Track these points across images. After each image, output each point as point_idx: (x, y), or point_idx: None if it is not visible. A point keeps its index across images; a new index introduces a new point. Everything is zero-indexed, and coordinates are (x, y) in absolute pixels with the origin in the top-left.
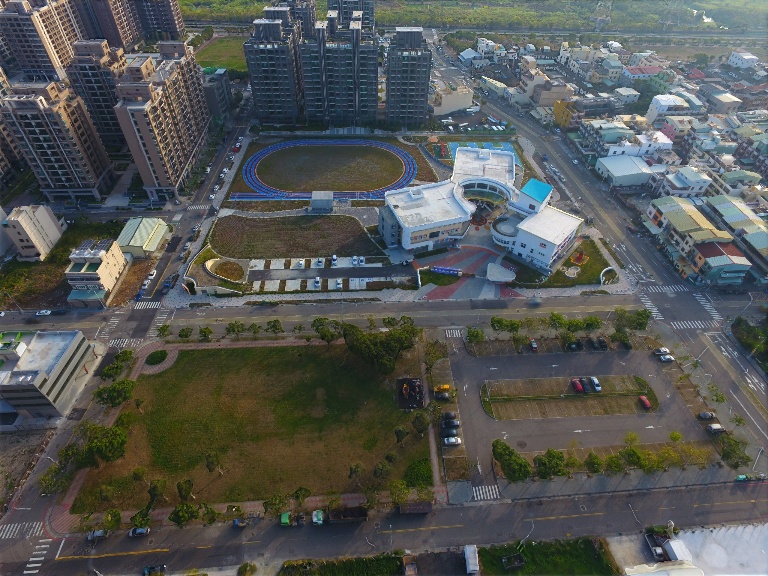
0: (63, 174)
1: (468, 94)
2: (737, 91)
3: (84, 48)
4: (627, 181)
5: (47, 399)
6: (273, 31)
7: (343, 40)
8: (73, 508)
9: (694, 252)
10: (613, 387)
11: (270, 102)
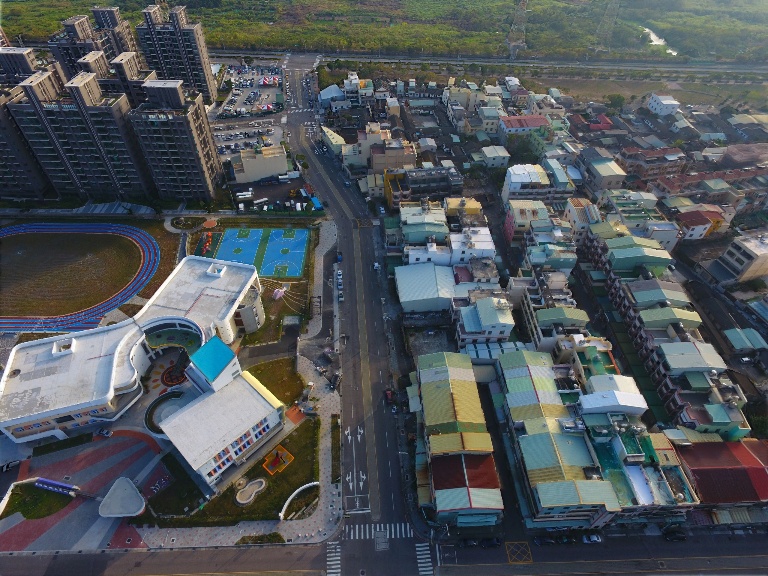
0: None
1: (279, 157)
2: (630, 156)
3: None
4: (421, 306)
5: None
6: None
7: None
8: None
9: (431, 470)
10: None
11: None
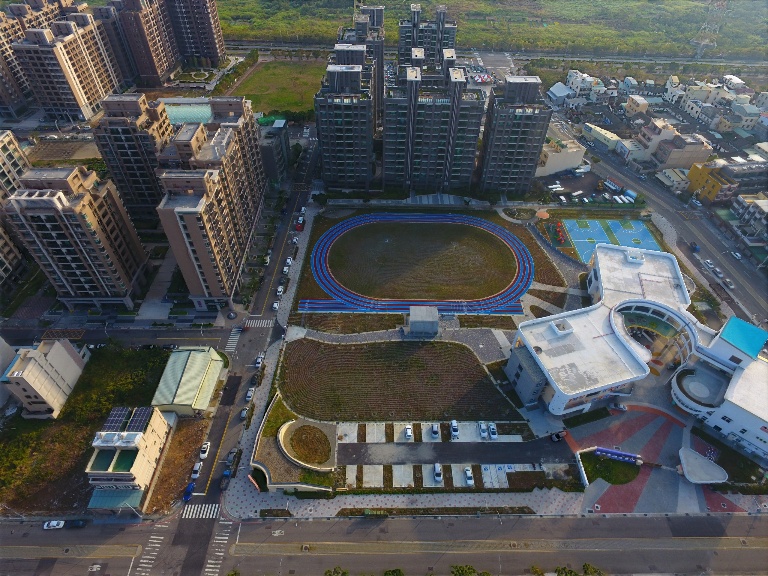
0: (86, 281)
1: (579, 152)
2: None
3: (116, 105)
4: None
5: None
6: (351, 80)
7: (437, 91)
8: None
9: None
10: None
11: (340, 164)
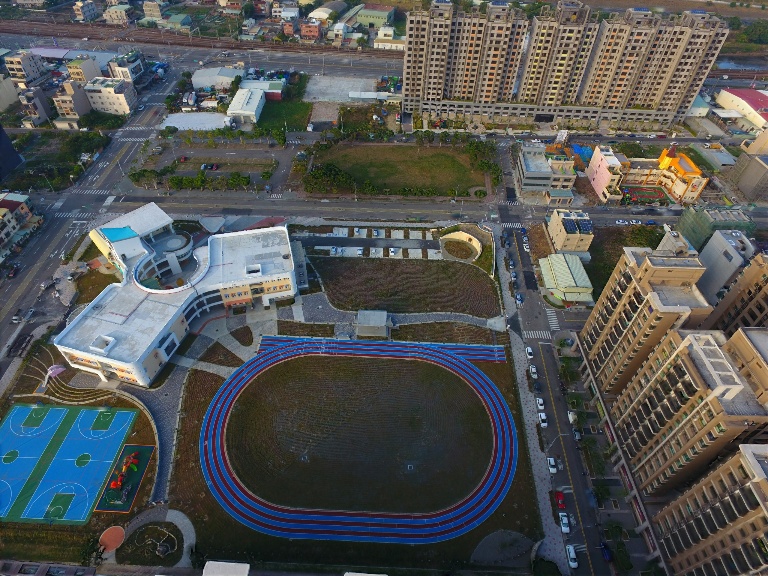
0: None
1: None
2: None
3: None
4: None
5: None
6: None
7: None
8: None
9: None
10: (194, 166)
11: None
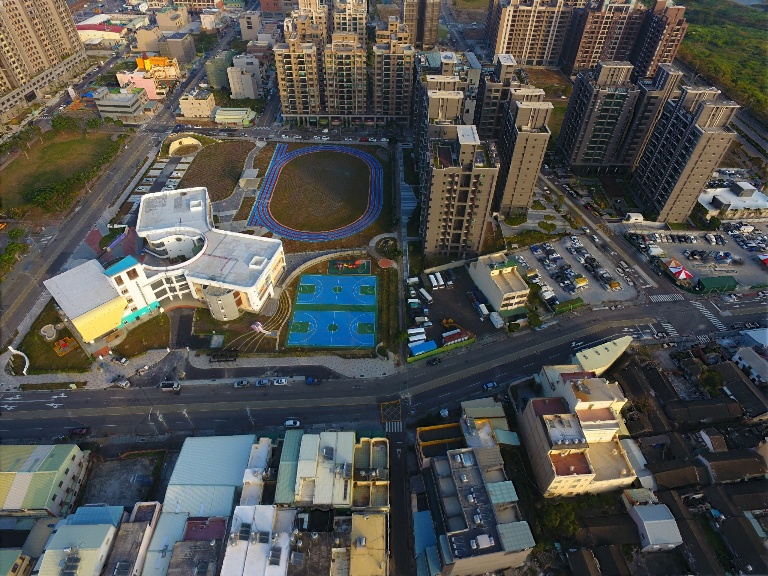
0: None
1: None
2: None
3: None
4: None
5: (98, 107)
6: None
7: None
8: (49, 130)
9: None
10: None
11: None
